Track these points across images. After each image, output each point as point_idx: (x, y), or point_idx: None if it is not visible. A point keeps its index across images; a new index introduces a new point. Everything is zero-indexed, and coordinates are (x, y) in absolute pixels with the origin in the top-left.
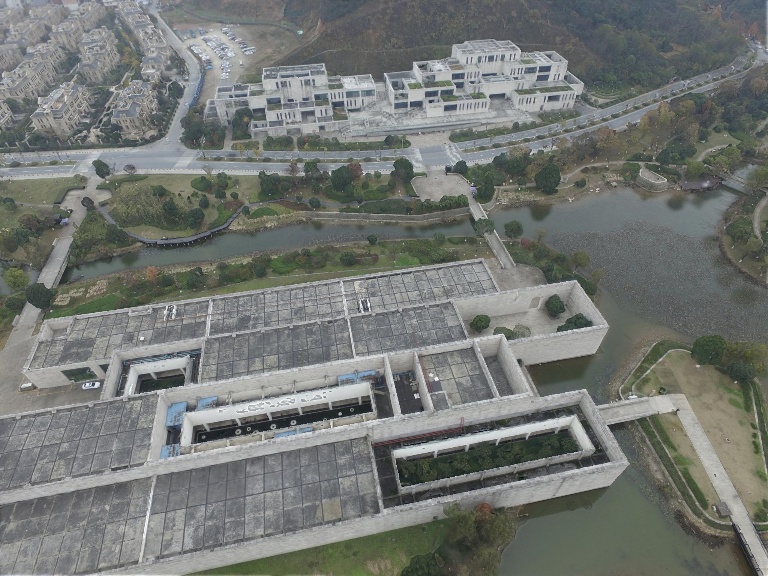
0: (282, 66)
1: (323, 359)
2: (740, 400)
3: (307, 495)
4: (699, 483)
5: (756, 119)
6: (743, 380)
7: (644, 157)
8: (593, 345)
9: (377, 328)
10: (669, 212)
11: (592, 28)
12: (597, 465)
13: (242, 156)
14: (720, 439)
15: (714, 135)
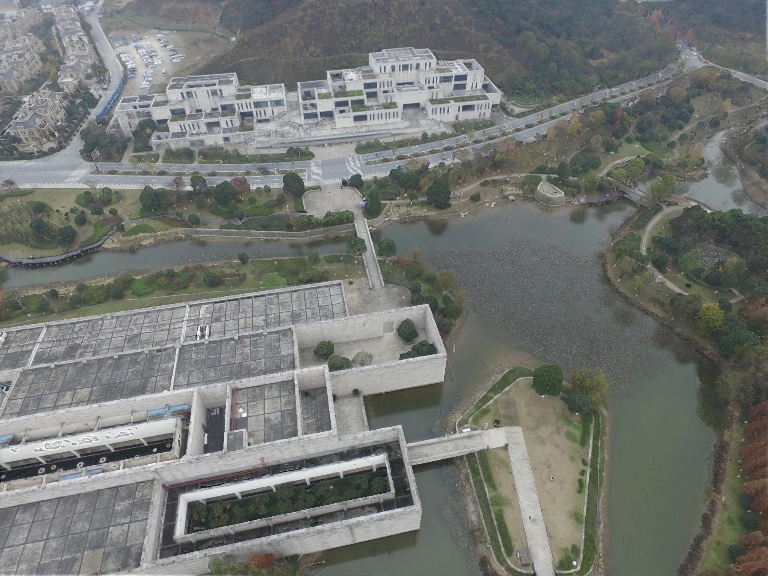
0: (191, 75)
1: (138, 392)
2: (577, 433)
3: (70, 546)
4: (510, 526)
5: (672, 129)
6: (580, 412)
7: (547, 169)
8: (437, 373)
9: (205, 357)
10: (561, 227)
11: (516, 35)
12: (387, 511)
13: (136, 169)
14: (545, 477)
15: (625, 146)
